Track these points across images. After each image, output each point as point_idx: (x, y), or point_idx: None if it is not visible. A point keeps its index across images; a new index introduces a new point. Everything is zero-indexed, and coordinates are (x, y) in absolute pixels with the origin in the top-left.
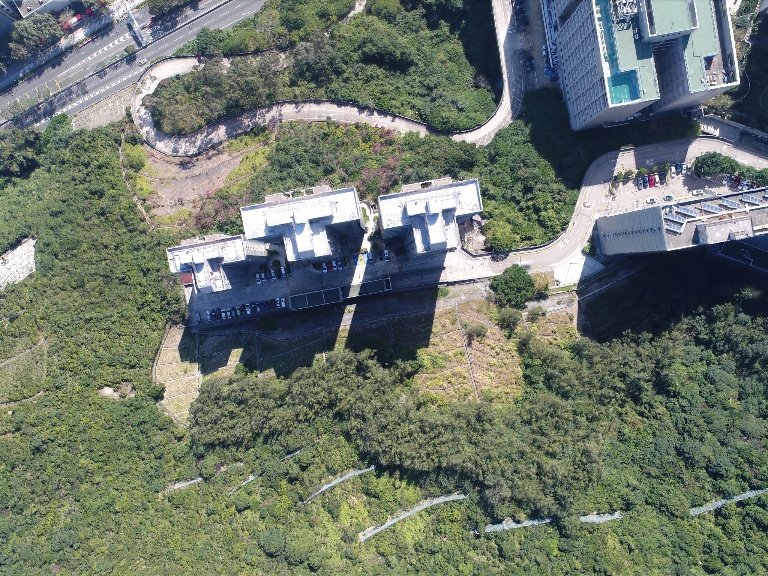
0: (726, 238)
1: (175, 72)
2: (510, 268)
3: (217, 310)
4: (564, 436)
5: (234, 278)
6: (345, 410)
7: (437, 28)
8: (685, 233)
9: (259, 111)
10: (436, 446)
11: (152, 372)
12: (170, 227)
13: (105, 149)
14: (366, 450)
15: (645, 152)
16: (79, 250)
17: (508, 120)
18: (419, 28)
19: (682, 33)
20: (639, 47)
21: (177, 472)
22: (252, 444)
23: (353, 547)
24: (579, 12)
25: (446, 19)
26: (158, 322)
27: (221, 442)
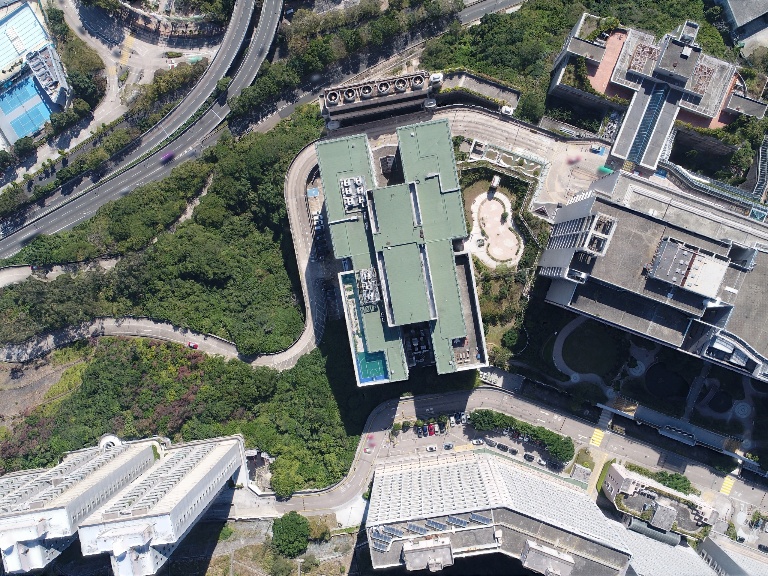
0: (425, 565)
1: (10, 280)
2: (286, 516)
3: None
4: None
5: None
6: None
7: (264, 232)
8: (392, 551)
9: (83, 323)
10: None
11: None
12: None
13: None
14: None
15: (425, 401)
16: None
17: (312, 345)
18: (247, 232)
19: None
20: (387, 329)
21: None
22: None
23: None
24: None
25: (271, 226)
26: None
27: None
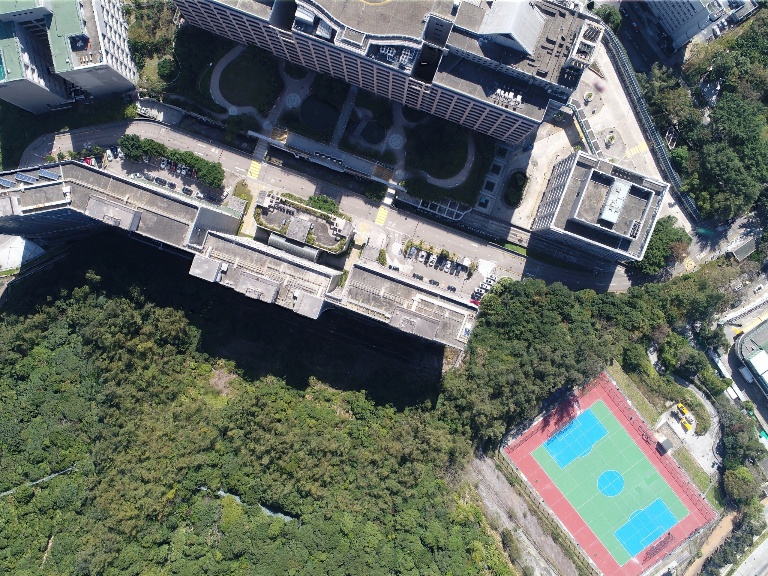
0: None
1: None
2: None
3: None
4: None
5: None
6: None
7: None
8: None
9: None
10: None
11: None
12: None
13: None
14: None
15: (82, 135)
16: None
17: None
18: None
19: (36, 12)
20: (2, 26)
21: None
22: None
23: None
24: None
25: None
26: None
27: None
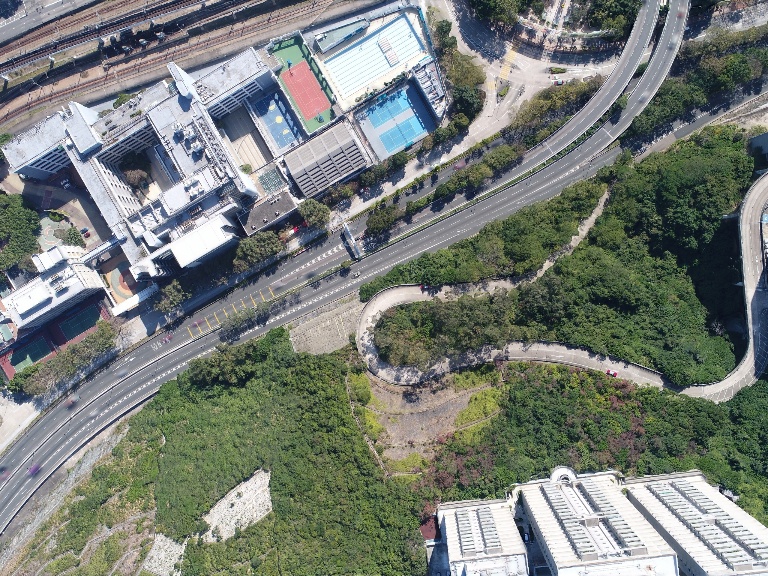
0: None
1: (398, 300)
2: None
3: None
4: None
5: None
6: None
7: (661, 256)
8: None
9: (485, 347)
10: None
11: None
12: (404, 474)
13: (332, 379)
14: None
15: None
16: (314, 491)
17: (751, 376)
18: (642, 255)
19: None
20: None
21: None
22: None
23: None
24: None
25: (672, 250)
26: None
27: None
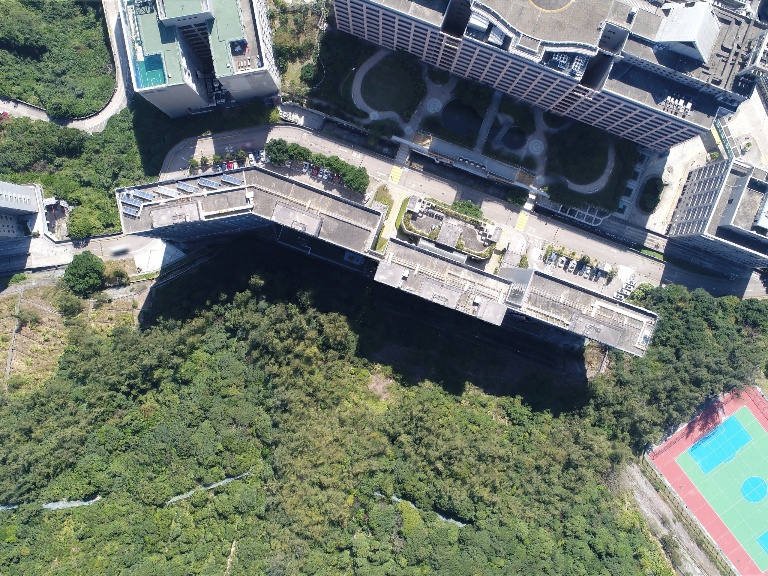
0: (172, 222)
1: None
2: None
3: None
4: (52, 422)
5: None
6: None
7: None
8: (144, 217)
9: None
10: None
11: None
12: None
13: None
14: None
15: (224, 139)
16: None
17: (124, 107)
18: (71, 15)
19: (200, 17)
20: (163, 31)
21: None
22: None
23: None
24: None
25: (94, 6)
26: None
27: None
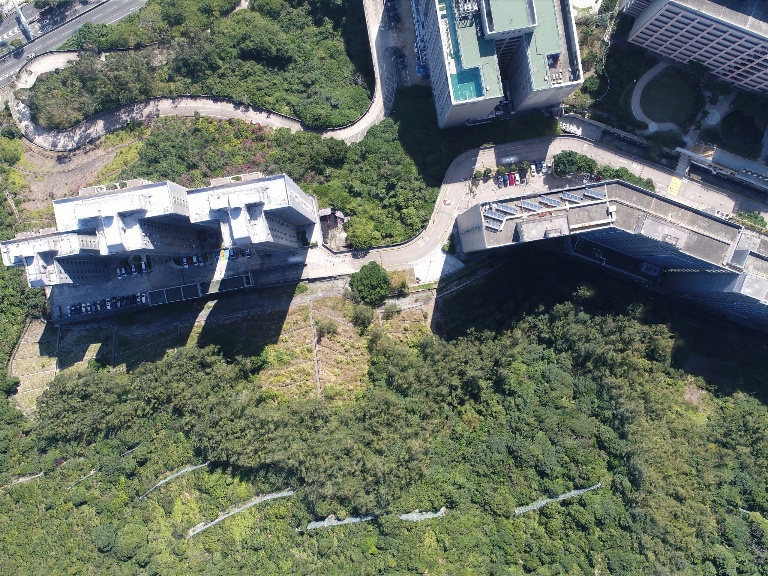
0: (542, 236)
1: (55, 66)
2: (366, 265)
3: (78, 305)
4: (393, 433)
5: (80, 272)
6: (182, 406)
7: (322, 25)
8: (505, 230)
9: (136, 106)
10: (265, 442)
11: (8, 366)
12: (37, 221)
13: None
14: (196, 446)
15: (505, 150)
16: None
17: (381, 117)
18: (305, 25)
19: (523, 31)
20: (482, 44)
21: (21, 466)
22: (93, 439)
23: (181, 543)
24: (430, 9)
25: (330, 16)
26: (17, 316)
27: (63, 437)
